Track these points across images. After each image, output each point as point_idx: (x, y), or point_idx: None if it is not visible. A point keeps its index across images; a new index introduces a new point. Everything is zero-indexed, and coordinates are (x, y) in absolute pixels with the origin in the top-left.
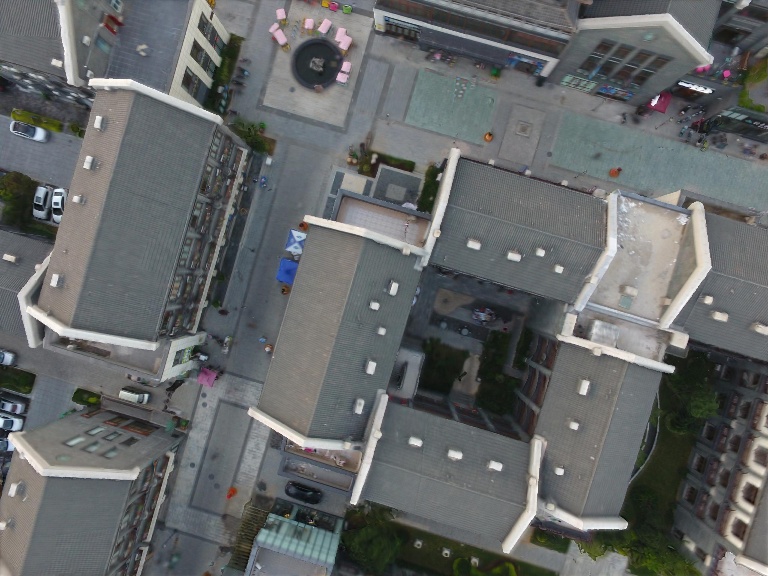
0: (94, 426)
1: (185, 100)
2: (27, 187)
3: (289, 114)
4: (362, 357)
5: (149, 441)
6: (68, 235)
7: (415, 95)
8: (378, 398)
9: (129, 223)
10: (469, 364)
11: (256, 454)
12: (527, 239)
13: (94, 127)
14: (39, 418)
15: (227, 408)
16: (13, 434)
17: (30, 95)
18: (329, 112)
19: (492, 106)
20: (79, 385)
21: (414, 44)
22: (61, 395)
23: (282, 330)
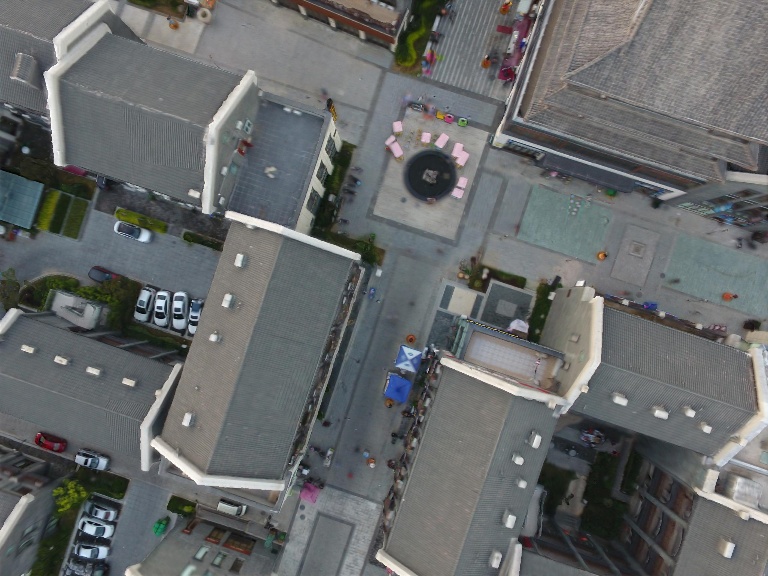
0: (198, 546)
1: (306, 218)
2: (132, 292)
3: (399, 224)
4: (501, 509)
5: (254, 563)
6: (200, 370)
7: (528, 211)
8: (511, 547)
9: (268, 365)
10: (575, 485)
11: (354, 570)
12: (676, 398)
13: (235, 265)
14: (130, 524)
15: (326, 521)
16: (130, 569)
17: (135, 194)
18: (440, 224)
19: (606, 225)
20: (173, 492)
21: (529, 160)
22: (154, 501)
23: (414, 473)
